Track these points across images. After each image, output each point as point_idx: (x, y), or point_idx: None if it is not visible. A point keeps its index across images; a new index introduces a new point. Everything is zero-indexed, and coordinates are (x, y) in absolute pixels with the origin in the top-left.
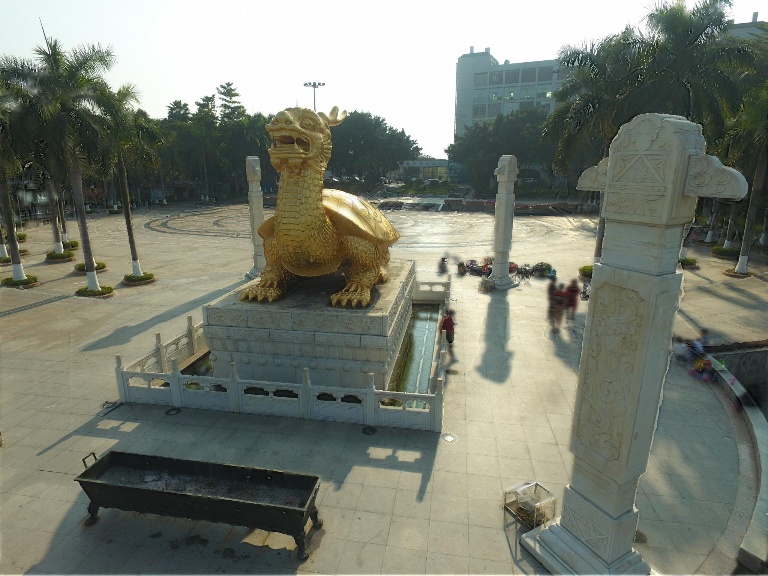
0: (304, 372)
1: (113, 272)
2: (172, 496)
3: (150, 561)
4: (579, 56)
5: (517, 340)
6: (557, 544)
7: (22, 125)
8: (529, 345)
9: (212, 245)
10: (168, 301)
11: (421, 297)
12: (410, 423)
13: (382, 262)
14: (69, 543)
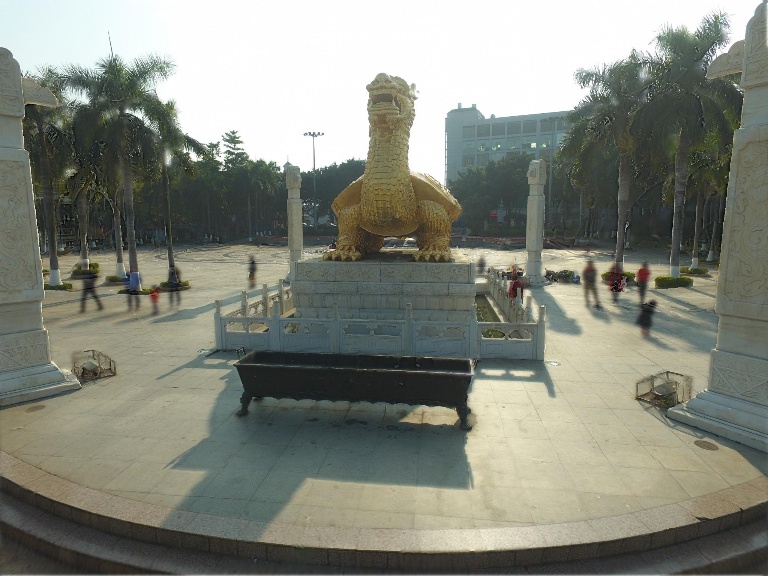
0: (408, 306)
1: (144, 283)
2: (335, 374)
3: (319, 433)
4: (593, 77)
5: (574, 312)
6: (709, 406)
7: (86, 125)
8: (588, 315)
9: (232, 268)
10: (216, 295)
11: None
12: (512, 353)
13: None
14: (230, 426)
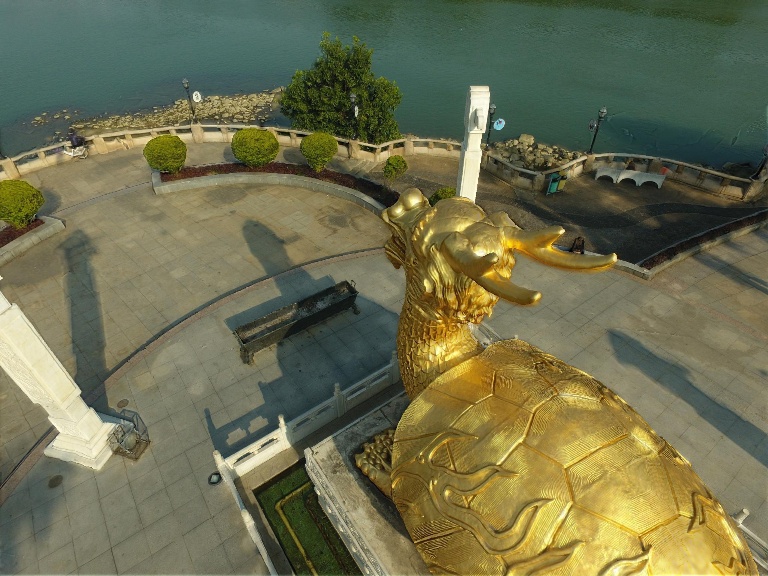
0: None
1: None
2: (301, 303)
3: None
4: None
5: None
6: None
7: None
8: None
9: None
10: None
11: None
12: None
13: None
14: None
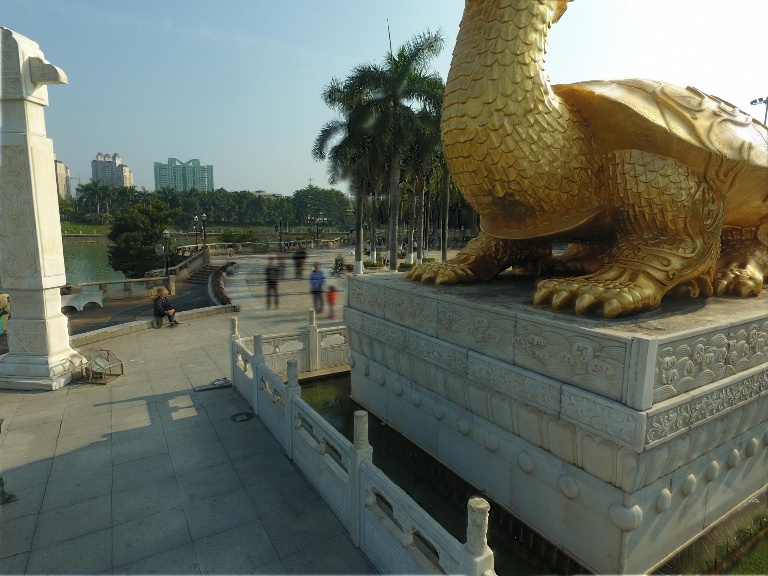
0: None
1: None
2: None
3: None
4: None
5: None
6: None
7: (356, 122)
8: None
9: None
10: None
11: None
12: None
13: (759, 258)
14: None
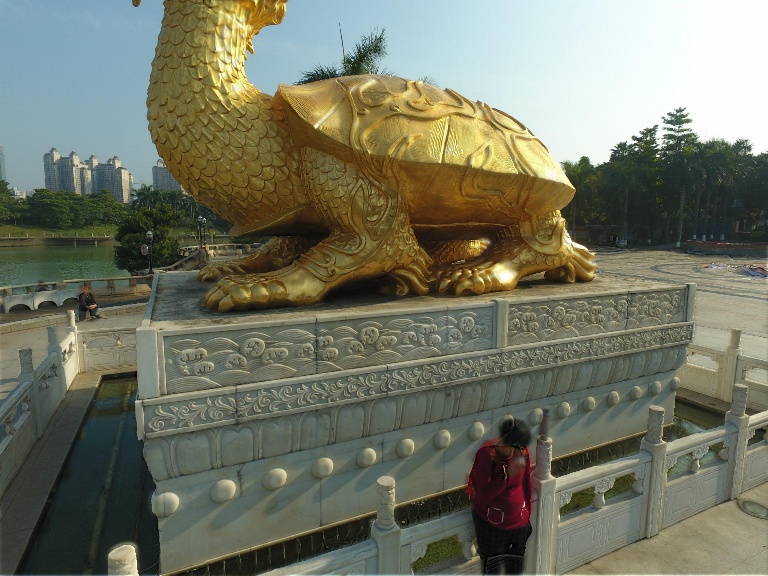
0: None
1: None
2: None
3: None
4: None
5: None
6: None
7: None
8: None
9: None
10: None
11: (749, 401)
12: None
13: (515, 256)
14: None
